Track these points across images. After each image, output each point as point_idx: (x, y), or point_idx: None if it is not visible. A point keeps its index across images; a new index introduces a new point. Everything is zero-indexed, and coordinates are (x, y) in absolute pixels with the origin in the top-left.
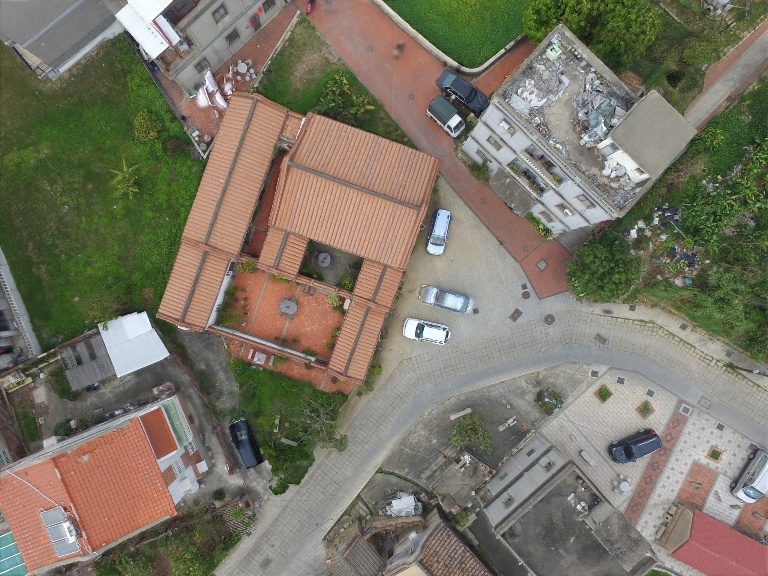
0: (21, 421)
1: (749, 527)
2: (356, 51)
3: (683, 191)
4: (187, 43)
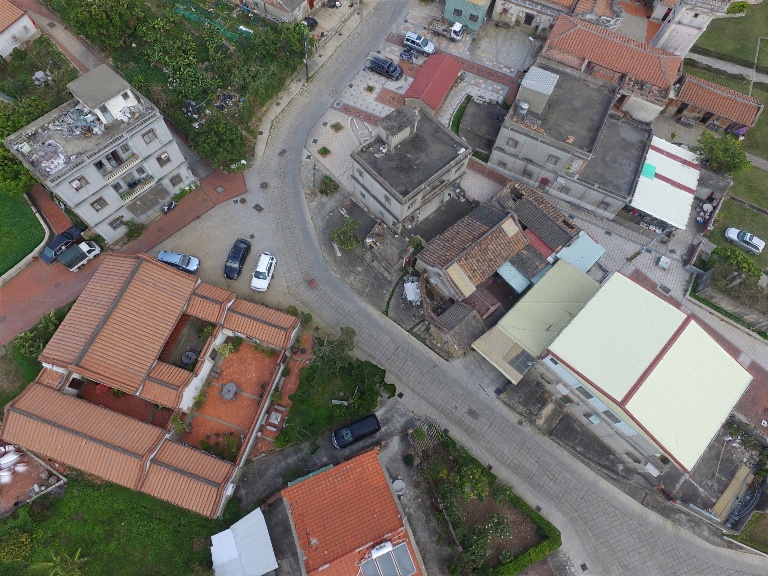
0: None
1: None
2: (1, 332)
3: None
4: None
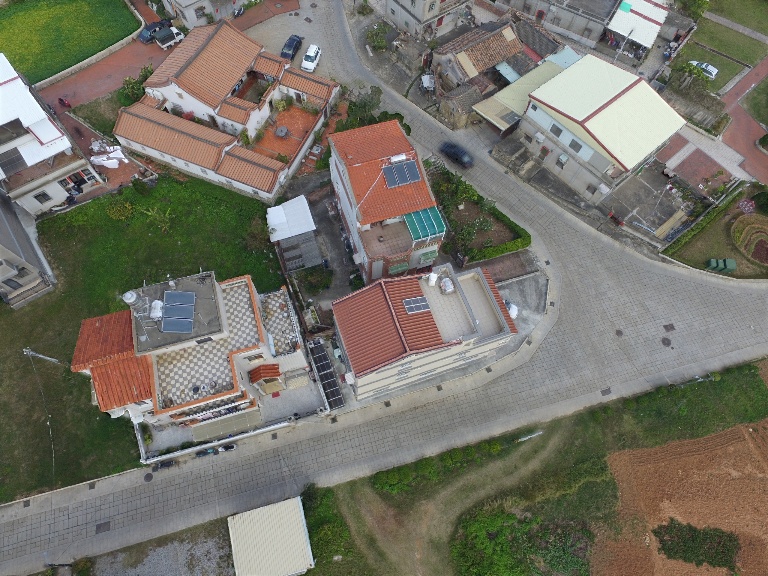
0: None
1: None
2: (108, 84)
3: None
4: None
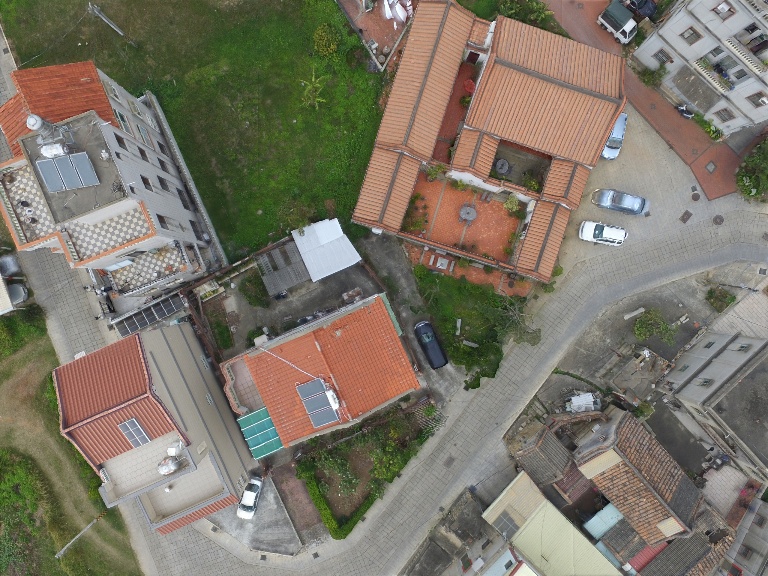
0: (214, 329)
1: None
2: None
3: None
4: None
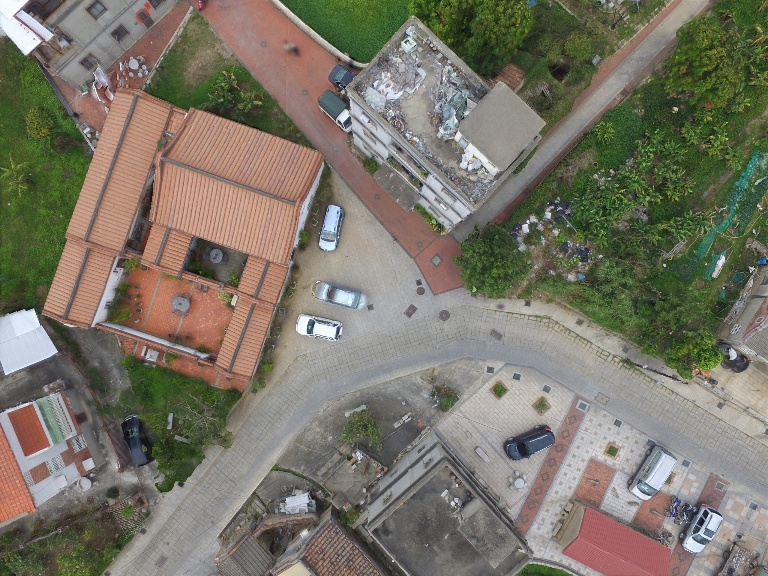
0: None
1: (647, 524)
2: (249, 47)
3: (574, 185)
4: (65, 39)
